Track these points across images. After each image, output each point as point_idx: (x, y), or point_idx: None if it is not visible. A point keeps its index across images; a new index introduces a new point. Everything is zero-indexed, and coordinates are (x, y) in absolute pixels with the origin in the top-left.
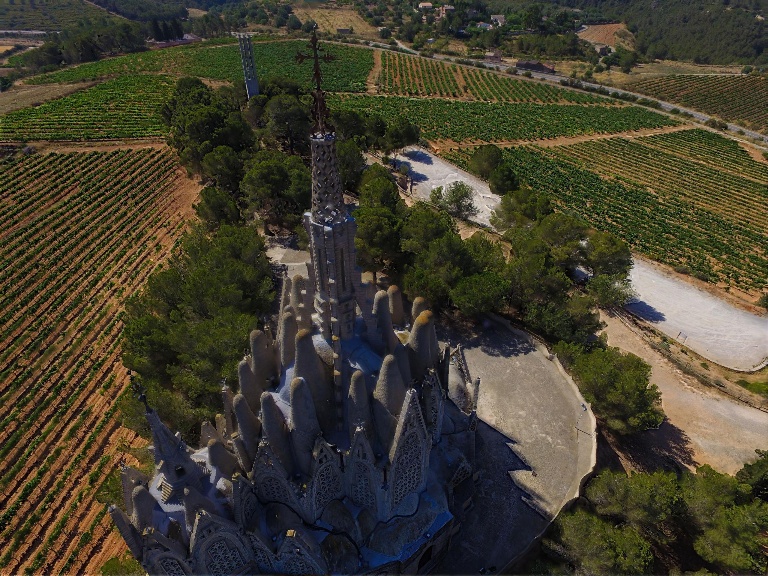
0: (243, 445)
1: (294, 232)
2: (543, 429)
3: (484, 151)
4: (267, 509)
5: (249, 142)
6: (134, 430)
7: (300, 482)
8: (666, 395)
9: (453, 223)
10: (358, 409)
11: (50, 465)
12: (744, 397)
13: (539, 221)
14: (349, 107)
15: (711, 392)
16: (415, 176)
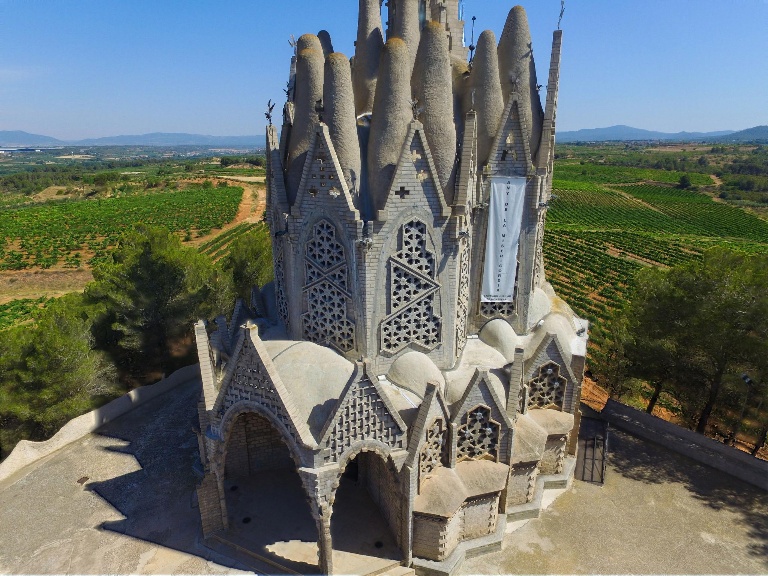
0: None
1: None
2: None
3: None
4: None
5: None
6: None
7: None
8: None
9: None
10: None
11: None
12: None
13: None
14: None
15: None
16: None
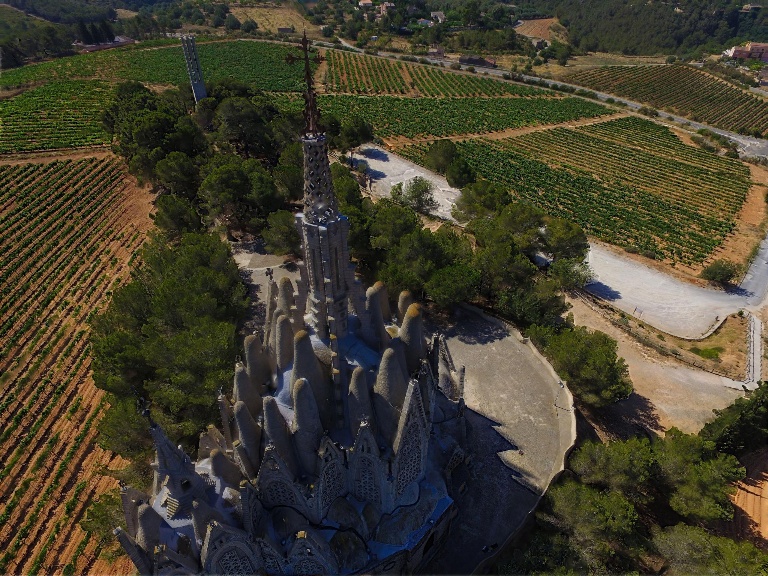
0: (245, 452)
1: (258, 236)
2: (525, 409)
3: (439, 146)
4: (273, 514)
5: (202, 147)
6: (116, 451)
7: (307, 483)
8: (630, 367)
9: (417, 218)
10: (360, 405)
11: (19, 499)
12: (698, 363)
13: (499, 211)
14: (298, 107)
15: (669, 361)
16: (373, 174)
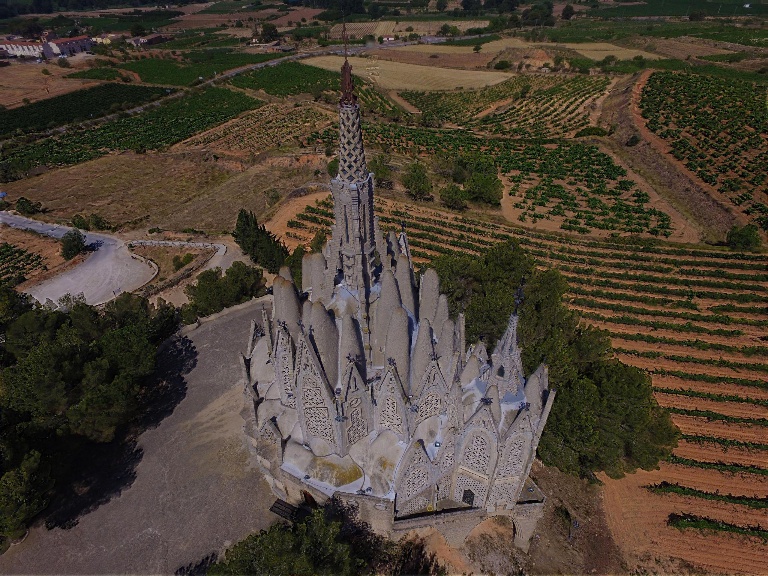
0: None
1: None
2: None
3: None
4: None
5: None
6: None
7: None
8: None
9: None
10: None
11: None
12: None
13: None
14: None
15: None
16: None
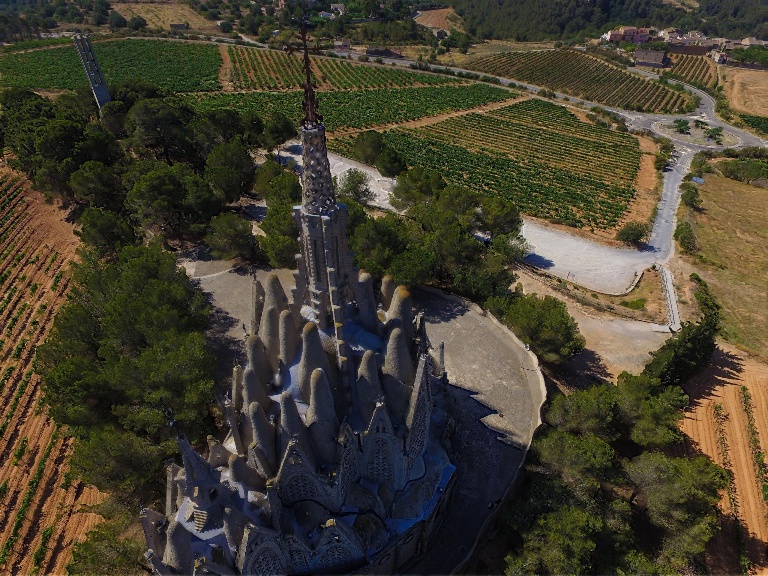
0: (262, 453)
1: (198, 243)
2: (496, 376)
3: (366, 137)
4: (295, 510)
5: (116, 154)
6: (96, 484)
7: (328, 472)
8: None
9: None
10: (372, 387)
11: None
12: (629, 314)
13: (436, 196)
14: None
15: (606, 316)
16: None
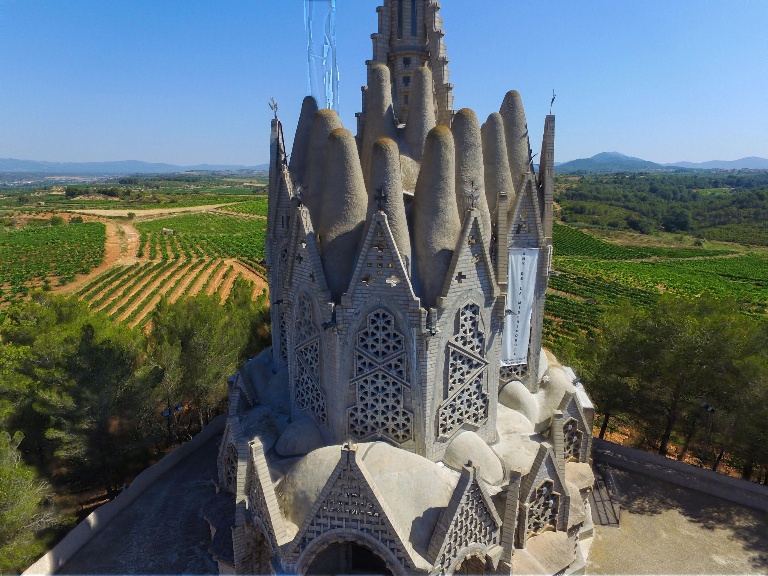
0: None
1: None
2: None
3: None
4: None
5: None
6: None
7: None
8: None
9: None
10: None
11: None
12: None
13: None
14: None
15: None
16: None
